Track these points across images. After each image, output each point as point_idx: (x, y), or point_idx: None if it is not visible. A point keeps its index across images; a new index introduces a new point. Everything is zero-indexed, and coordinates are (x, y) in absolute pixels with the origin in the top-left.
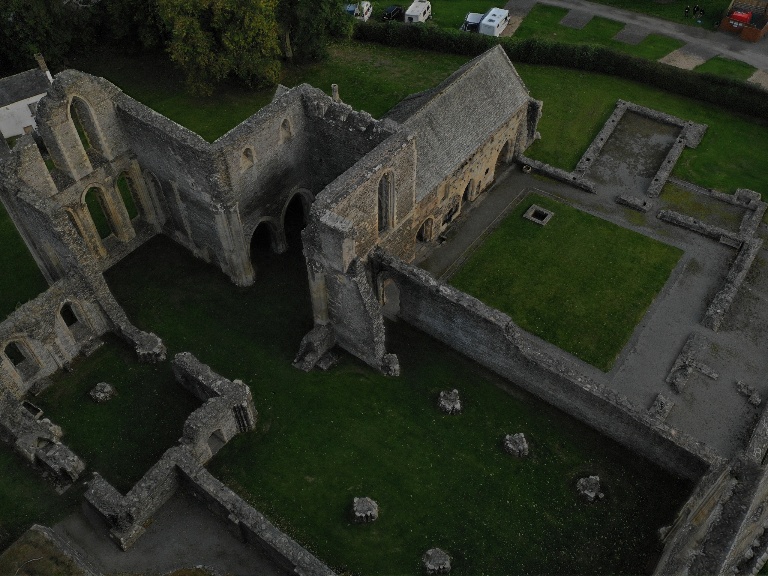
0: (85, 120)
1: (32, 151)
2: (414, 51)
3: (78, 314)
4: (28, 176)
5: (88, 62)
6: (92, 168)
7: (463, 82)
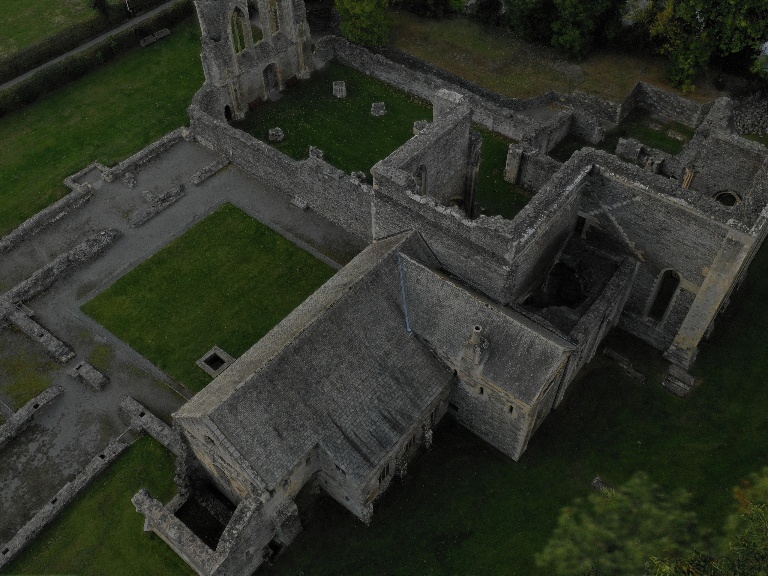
0: None
1: None
2: None
3: None
4: None
5: None
6: None
7: None
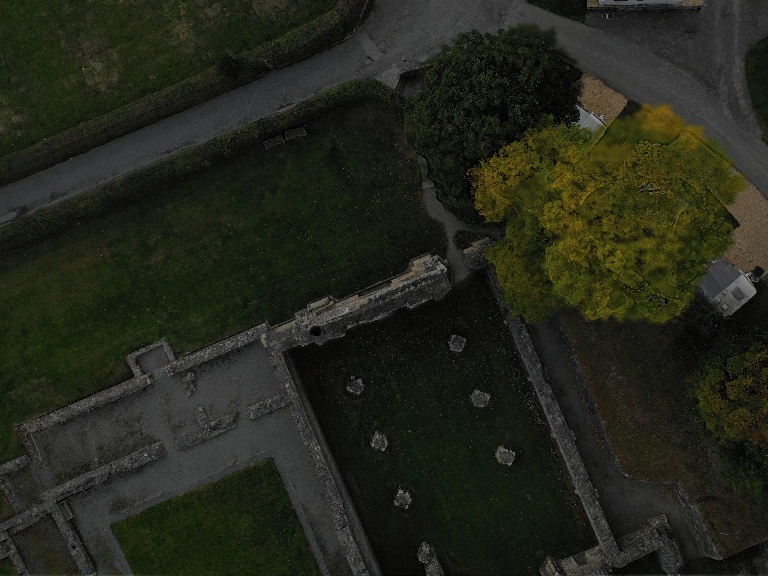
0: None
1: None
2: None
3: None
4: None
5: None
6: None
7: None
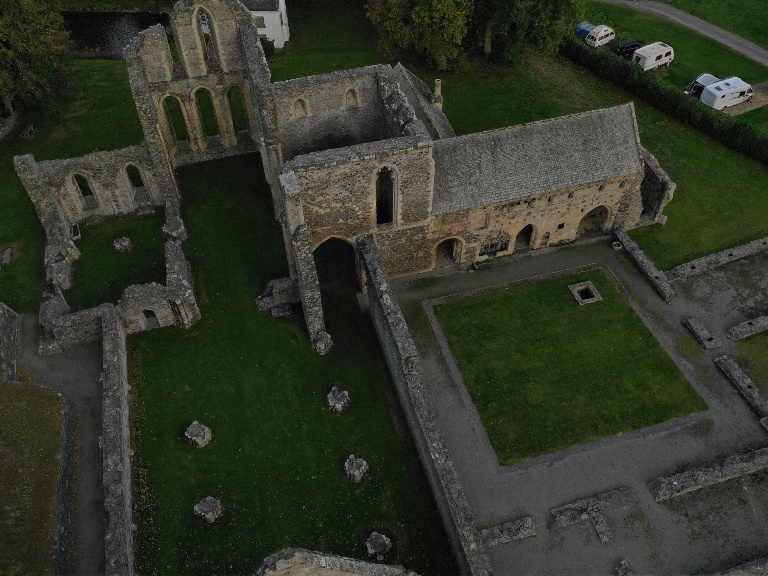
0: (212, 31)
1: (155, 39)
2: (617, 91)
3: (143, 180)
4: (147, 57)
5: (339, 1)
6: (206, 72)
7: (560, 124)
